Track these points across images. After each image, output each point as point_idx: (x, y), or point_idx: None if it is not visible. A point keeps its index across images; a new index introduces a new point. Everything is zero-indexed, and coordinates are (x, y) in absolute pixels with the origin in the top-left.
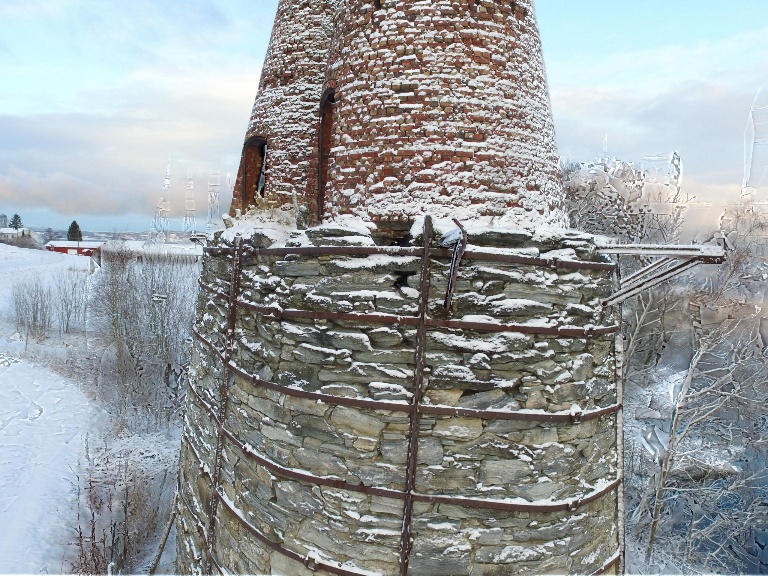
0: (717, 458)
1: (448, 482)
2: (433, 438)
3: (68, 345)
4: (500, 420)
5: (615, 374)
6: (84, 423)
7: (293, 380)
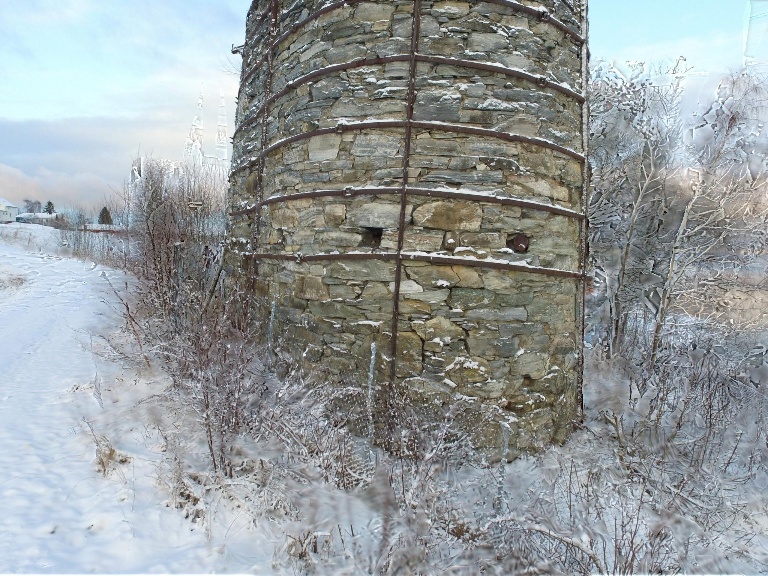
0: (712, 296)
1: (443, 48)
2: (432, 17)
3: (112, 249)
4: (483, 2)
5: (580, 16)
6: (132, 285)
7: (325, 2)
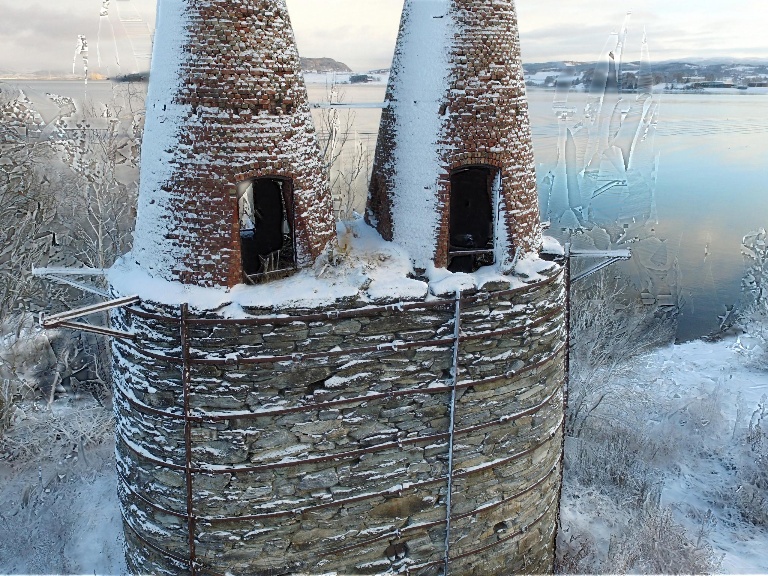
0: None
1: None
2: None
3: None
4: None
5: None
6: None
7: None
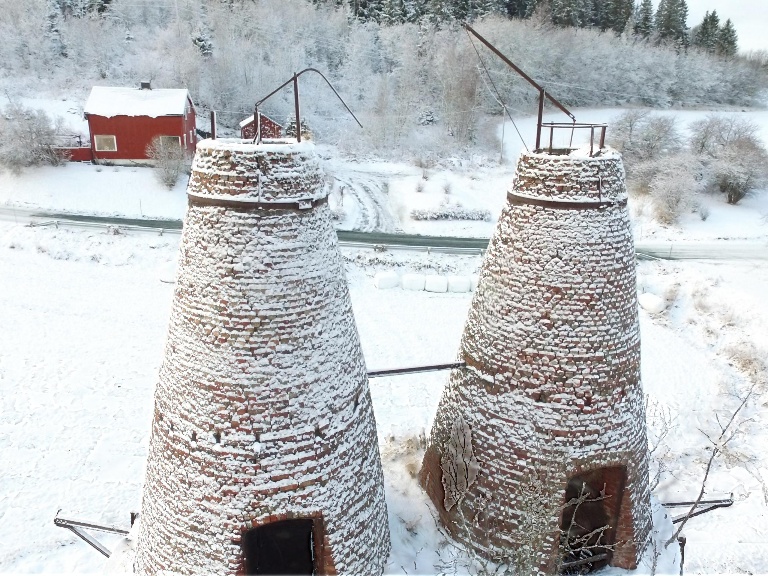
0: None
1: None
2: None
3: None
4: None
5: None
6: None
7: None
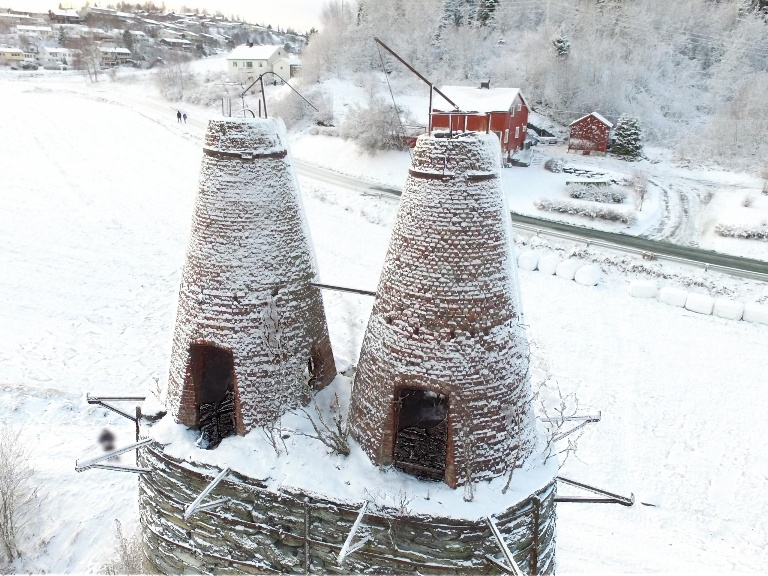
0: None
1: None
2: None
3: None
4: None
5: None
6: None
7: None
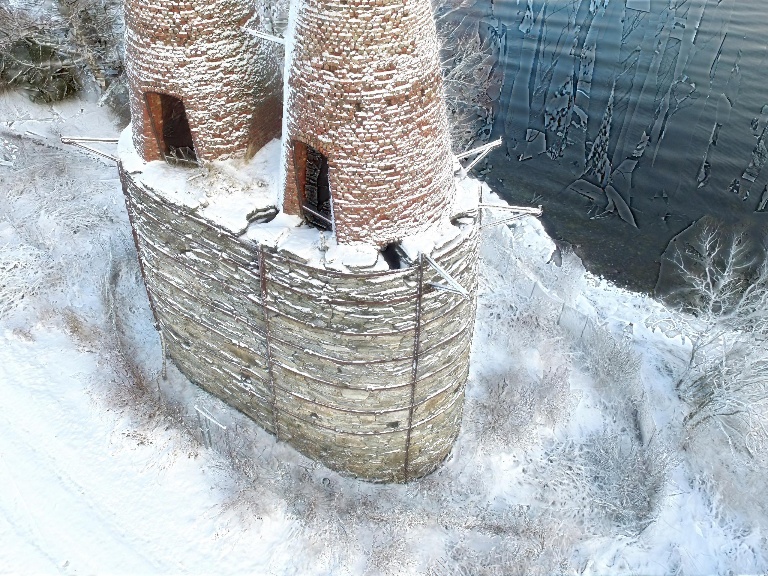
0: None
1: None
2: None
3: None
4: None
5: None
6: None
7: (347, 329)
